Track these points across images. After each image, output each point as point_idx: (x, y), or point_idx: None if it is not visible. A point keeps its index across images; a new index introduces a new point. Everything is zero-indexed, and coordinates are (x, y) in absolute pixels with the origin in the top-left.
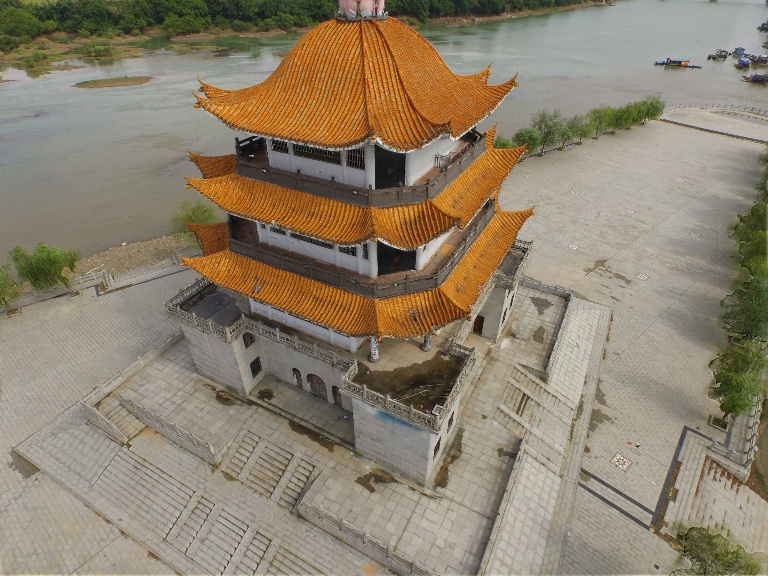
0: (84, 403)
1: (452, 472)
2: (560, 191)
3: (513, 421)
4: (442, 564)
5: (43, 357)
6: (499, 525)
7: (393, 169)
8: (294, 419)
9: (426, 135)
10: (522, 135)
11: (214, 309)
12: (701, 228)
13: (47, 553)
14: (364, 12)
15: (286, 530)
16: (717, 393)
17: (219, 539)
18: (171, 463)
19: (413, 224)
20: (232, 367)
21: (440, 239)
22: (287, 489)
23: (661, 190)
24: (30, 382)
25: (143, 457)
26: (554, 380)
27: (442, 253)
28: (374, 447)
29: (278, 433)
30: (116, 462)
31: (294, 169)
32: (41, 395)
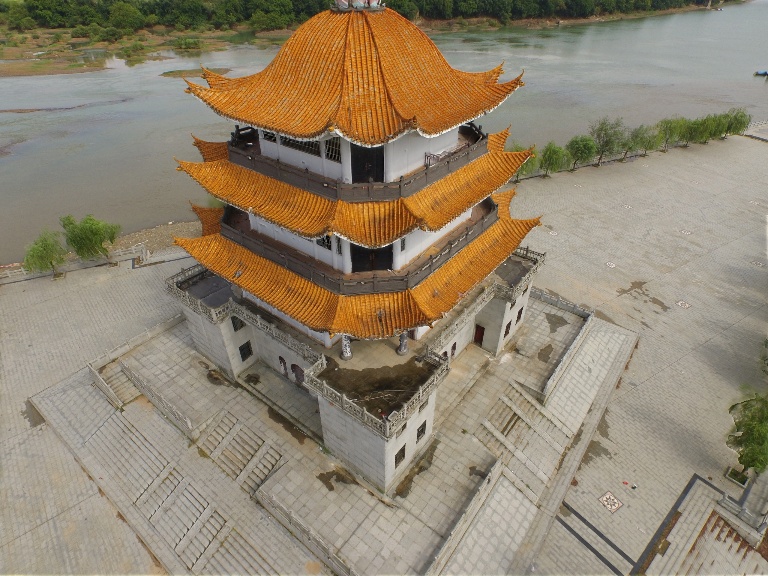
0: (89, 365)
1: (416, 483)
2: (610, 205)
3: (496, 440)
4: (382, 575)
5: (73, 319)
6: (455, 546)
7: (371, 164)
8: (273, 406)
9: (394, 130)
10: (577, 143)
11: (210, 290)
12: (767, 257)
13: (33, 498)
14: (356, 3)
15: (242, 514)
16: (737, 442)
17: (181, 511)
18: (154, 432)
19: (382, 222)
20: (221, 348)
21: (426, 241)
22: (252, 474)
23: (728, 212)
24: (57, 340)
25: (132, 423)
26: (553, 403)
27: (426, 256)
28: (339, 445)
29: (255, 418)
30: (108, 424)
31: (281, 159)
32: (63, 353)
